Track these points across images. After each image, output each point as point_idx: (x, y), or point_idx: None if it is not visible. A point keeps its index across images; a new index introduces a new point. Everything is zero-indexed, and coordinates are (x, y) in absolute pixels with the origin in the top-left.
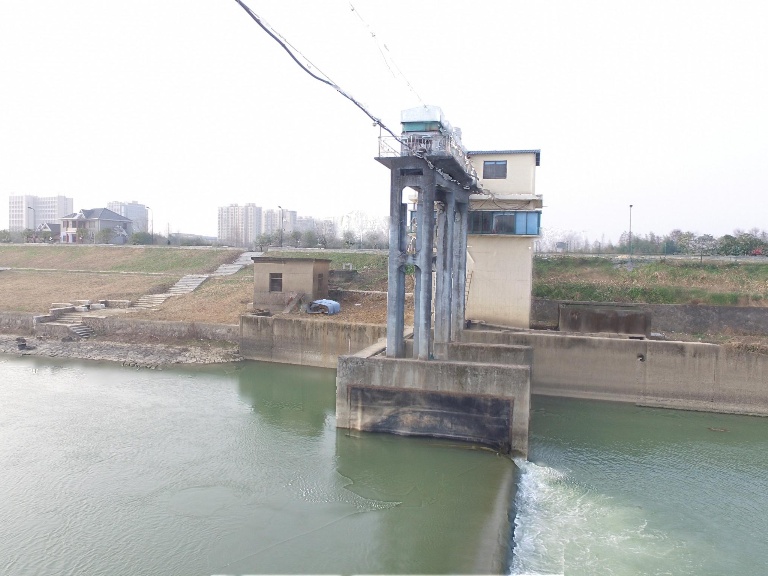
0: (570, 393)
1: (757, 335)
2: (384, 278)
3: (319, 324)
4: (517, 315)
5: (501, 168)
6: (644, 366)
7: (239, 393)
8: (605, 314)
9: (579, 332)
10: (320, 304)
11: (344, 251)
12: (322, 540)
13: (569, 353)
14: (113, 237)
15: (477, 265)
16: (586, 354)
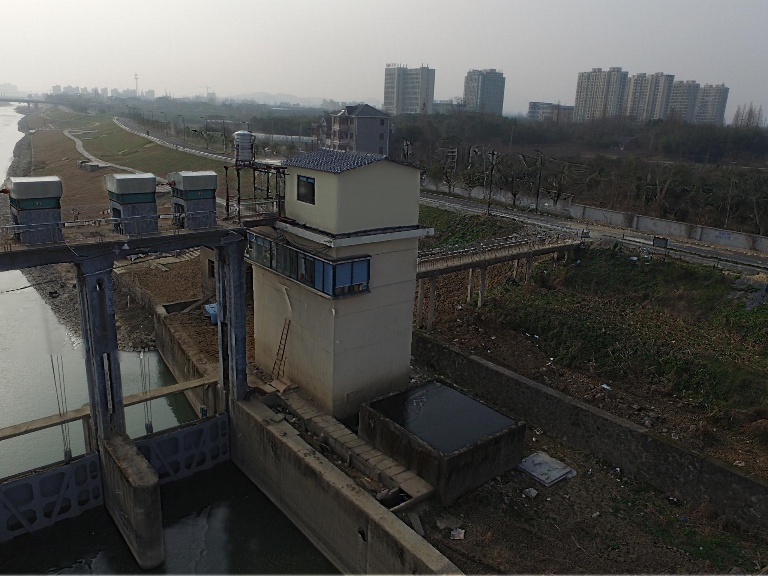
0: (306, 532)
1: (745, 541)
2: None
3: (175, 339)
4: (323, 393)
5: (312, 188)
6: (365, 548)
7: (159, 378)
8: (398, 436)
9: (367, 447)
10: (207, 310)
11: (428, 203)
12: None
13: (304, 482)
14: (298, 153)
15: (293, 314)
16: (317, 493)
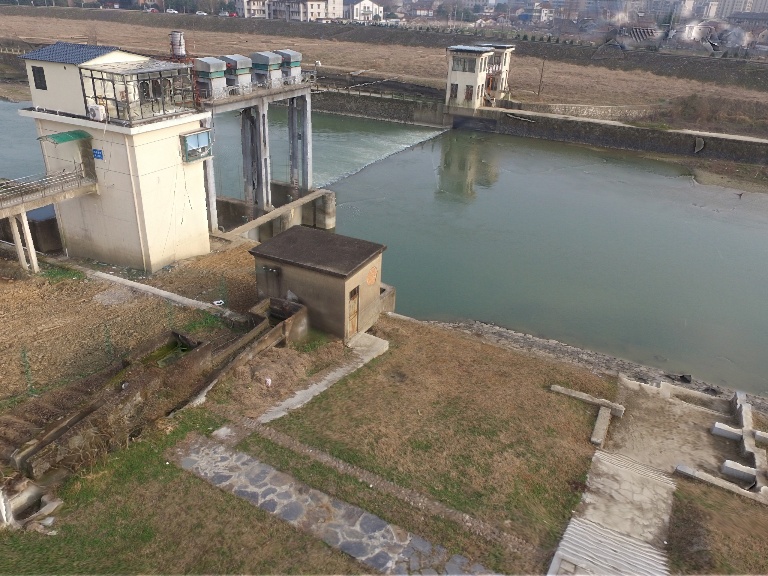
0: None
1: None
2: (3, 400)
3: None
4: None
5: None
6: None
7: None
8: None
9: None
10: None
11: None
12: (358, 199)
13: None
14: None
15: None
16: None
